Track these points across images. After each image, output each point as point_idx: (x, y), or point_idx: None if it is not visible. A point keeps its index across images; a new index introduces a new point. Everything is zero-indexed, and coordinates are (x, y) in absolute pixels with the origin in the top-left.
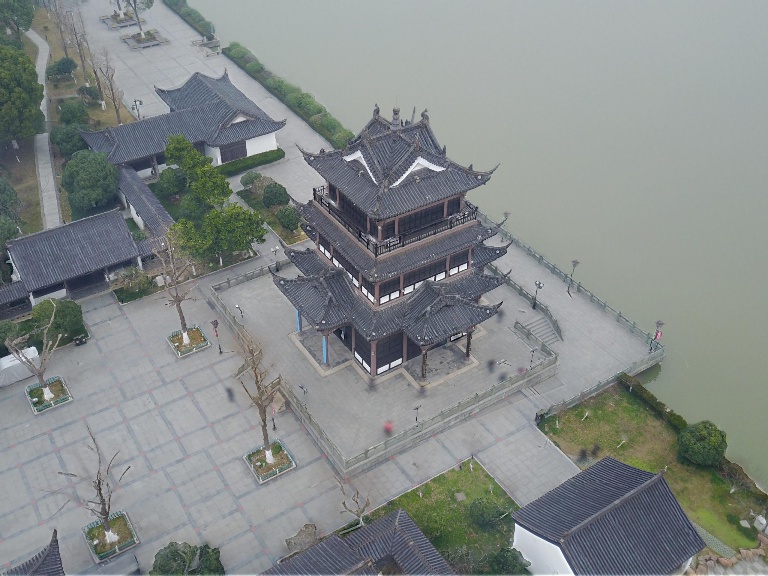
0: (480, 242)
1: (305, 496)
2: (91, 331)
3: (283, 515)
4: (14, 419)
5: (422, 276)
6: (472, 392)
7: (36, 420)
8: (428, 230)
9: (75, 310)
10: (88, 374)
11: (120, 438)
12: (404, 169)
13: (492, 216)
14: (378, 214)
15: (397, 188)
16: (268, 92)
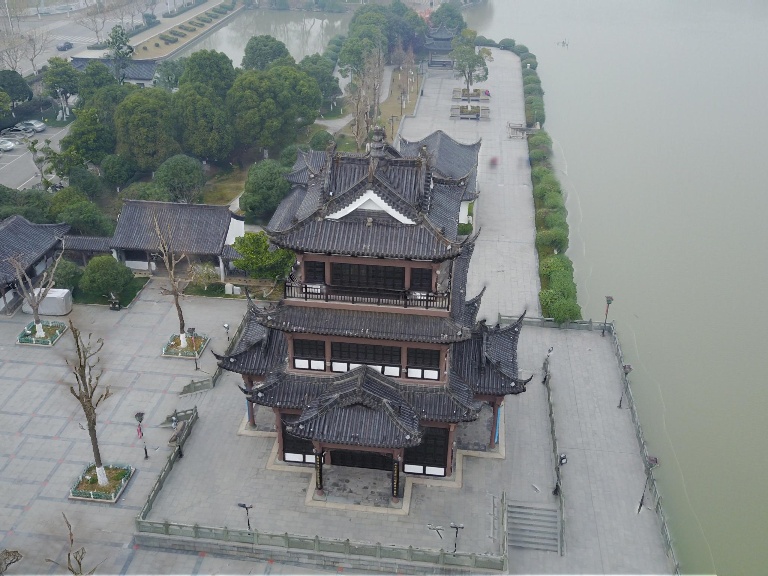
0: (496, 362)
1: (85, 534)
2: (135, 304)
3: (46, 538)
4: (2, 339)
5: (362, 357)
6: (359, 538)
7: (12, 348)
8: (367, 294)
9: (120, 274)
10: (88, 333)
11: (37, 393)
12: (349, 200)
13: (648, 378)
14: (281, 238)
15: (336, 222)
16: (530, 180)
